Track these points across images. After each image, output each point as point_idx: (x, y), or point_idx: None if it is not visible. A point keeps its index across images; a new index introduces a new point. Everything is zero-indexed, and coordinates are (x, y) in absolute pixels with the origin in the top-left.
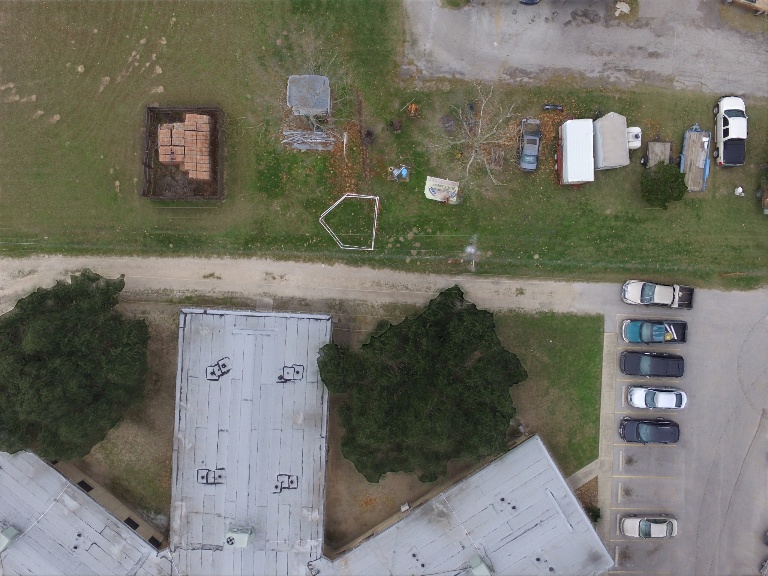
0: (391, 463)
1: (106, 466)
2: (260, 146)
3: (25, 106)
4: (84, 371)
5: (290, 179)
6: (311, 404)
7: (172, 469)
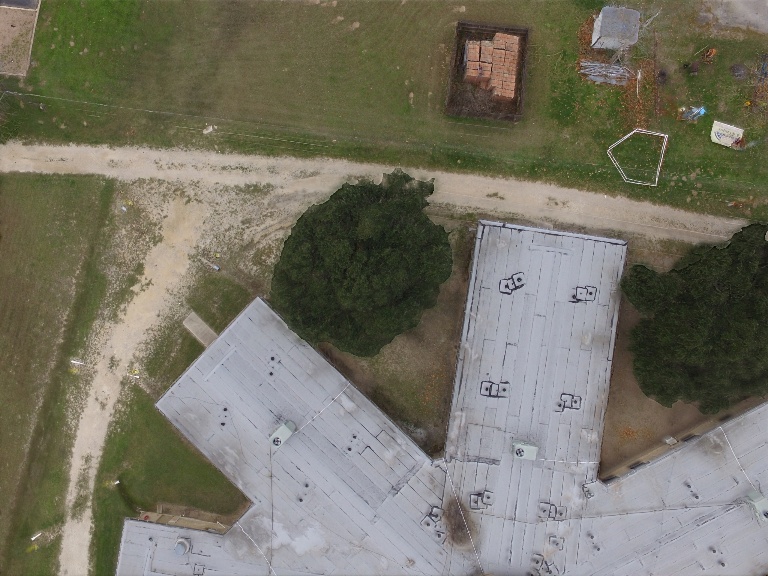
0: (689, 388)
1: (370, 374)
2: (555, 74)
3: (325, 10)
4: (405, 265)
5: (582, 109)
6: (601, 326)
7: (456, 378)
